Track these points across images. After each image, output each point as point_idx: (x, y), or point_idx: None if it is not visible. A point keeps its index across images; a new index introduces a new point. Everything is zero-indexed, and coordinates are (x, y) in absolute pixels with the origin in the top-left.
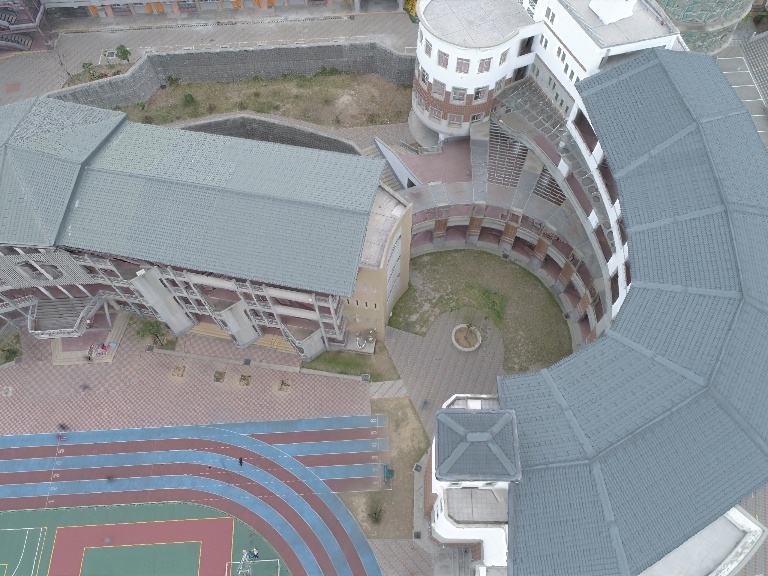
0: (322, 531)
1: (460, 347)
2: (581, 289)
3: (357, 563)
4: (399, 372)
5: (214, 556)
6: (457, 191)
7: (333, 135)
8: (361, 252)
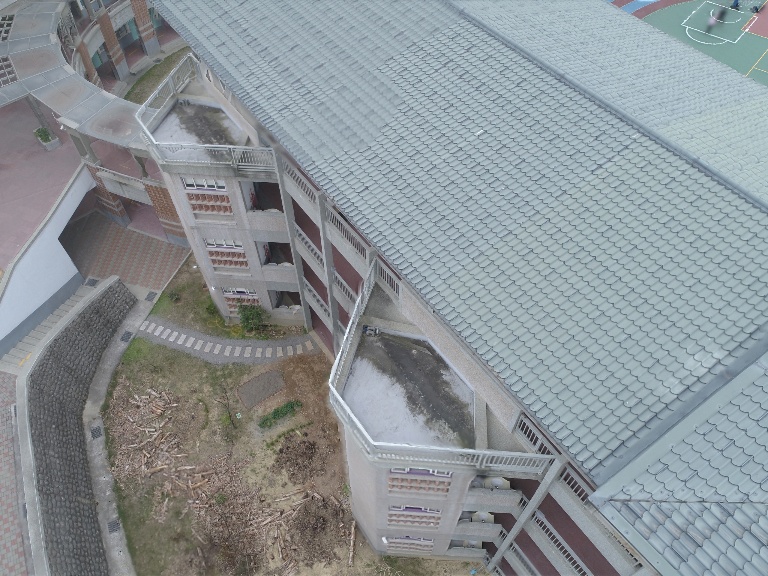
0: None
1: None
2: (127, 6)
3: None
4: None
5: None
6: (66, 96)
7: (18, 432)
8: None
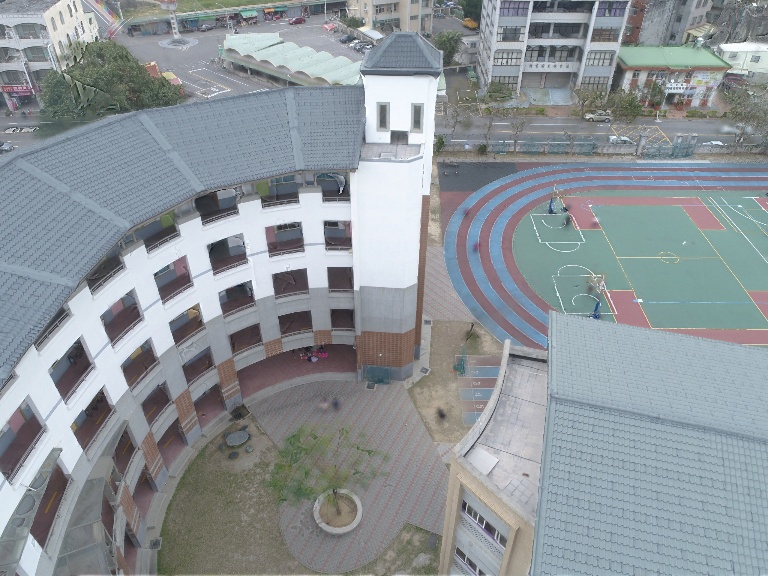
0: (527, 330)
1: (351, 495)
2: None
3: (487, 308)
4: (448, 473)
5: (633, 318)
6: None
7: None
8: (550, 349)
